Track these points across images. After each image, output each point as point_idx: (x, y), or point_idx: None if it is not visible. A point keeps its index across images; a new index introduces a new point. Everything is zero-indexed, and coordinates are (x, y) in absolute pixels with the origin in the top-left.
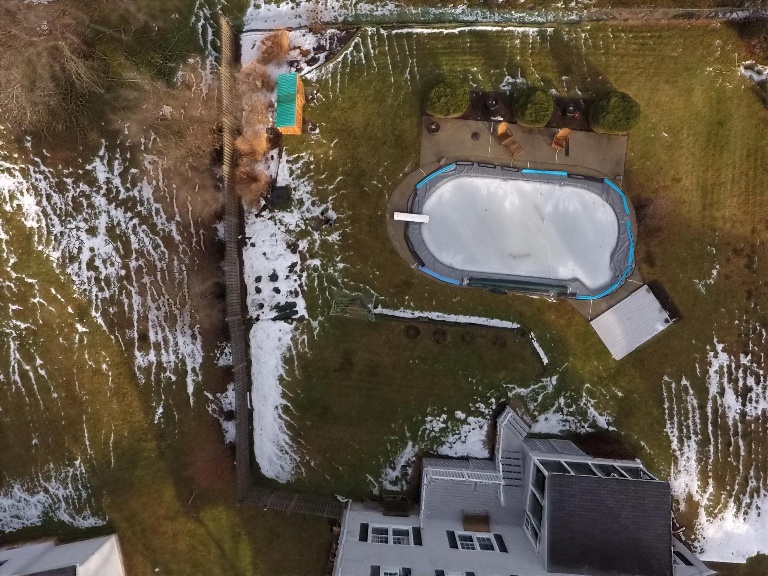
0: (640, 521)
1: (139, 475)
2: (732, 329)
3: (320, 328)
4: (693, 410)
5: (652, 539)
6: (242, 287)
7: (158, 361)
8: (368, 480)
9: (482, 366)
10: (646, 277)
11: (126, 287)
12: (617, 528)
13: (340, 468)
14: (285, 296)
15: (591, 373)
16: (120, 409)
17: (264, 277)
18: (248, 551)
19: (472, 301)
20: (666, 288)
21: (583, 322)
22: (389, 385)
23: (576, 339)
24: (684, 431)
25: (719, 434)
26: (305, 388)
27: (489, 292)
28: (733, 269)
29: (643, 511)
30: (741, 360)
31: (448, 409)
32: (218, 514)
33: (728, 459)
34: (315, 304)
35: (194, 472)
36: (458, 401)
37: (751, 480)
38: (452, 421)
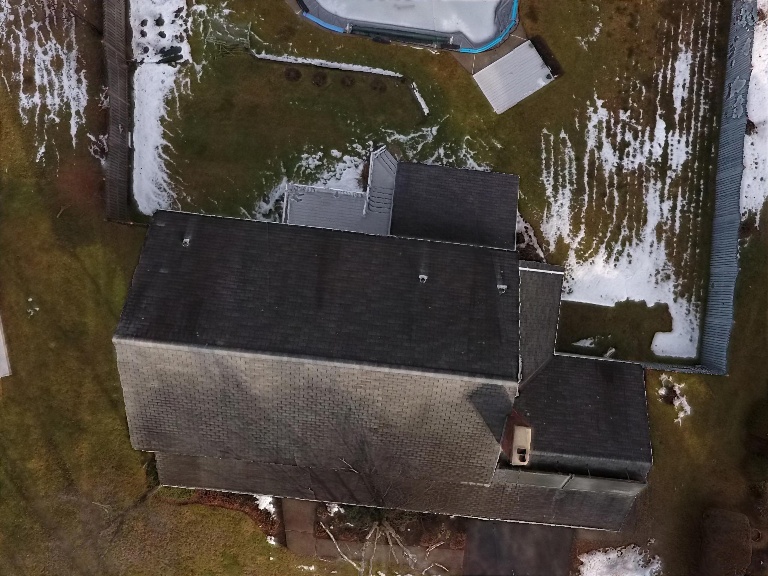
0: (486, 207)
1: (16, 207)
2: (613, 86)
3: (204, 72)
4: (570, 161)
5: (496, 223)
6: (127, 29)
7: (43, 103)
8: (242, 213)
9: (361, 109)
10: (529, 33)
11: (14, 32)
12: (462, 211)
13: (215, 202)
14: (170, 40)
15: (472, 125)
16: (2, 147)
17: (150, 21)
18: (123, 286)
19: (356, 50)
20: (549, 44)
21: (466, 75)
22: (267, 123)
23: (458, 92)
24: (560, 180)
25: (595, 185)
26: (186, 128)
27: (373, 41)
28: (616, 27)
29: (490, 198)
30: (620, 116)
31: (325, 147)
32: (95, 251)
33: (602, 208)
34: (200, 49)
35: (73, 209)
36: (335, 140)
37: (624, 229)
38: (328, 159)
